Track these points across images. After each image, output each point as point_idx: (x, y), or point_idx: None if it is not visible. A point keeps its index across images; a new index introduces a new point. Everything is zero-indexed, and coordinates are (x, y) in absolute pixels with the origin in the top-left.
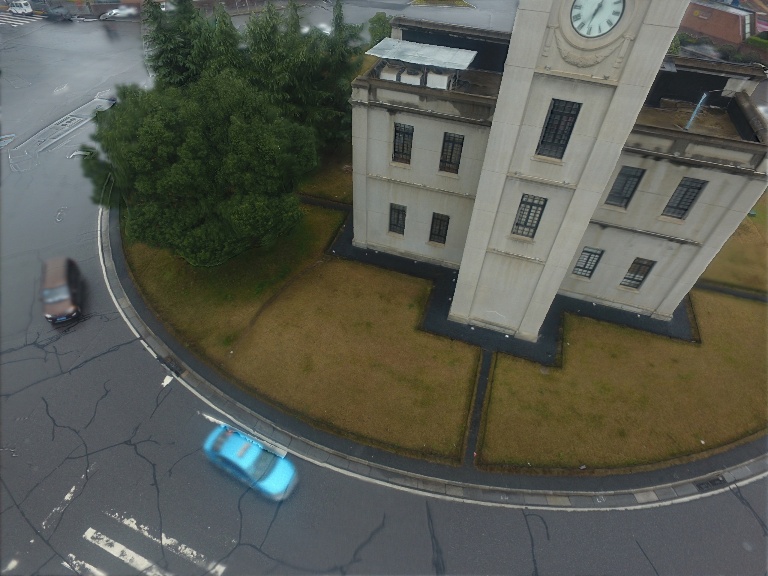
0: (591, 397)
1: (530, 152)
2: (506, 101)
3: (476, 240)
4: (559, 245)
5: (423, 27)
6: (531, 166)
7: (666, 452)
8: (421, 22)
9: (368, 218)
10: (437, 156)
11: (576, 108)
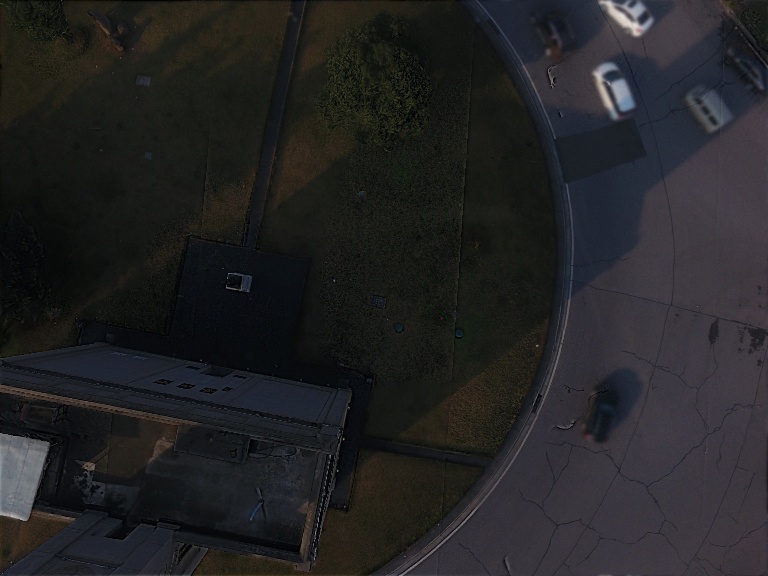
0: (256, 569)
1: None
2: None
3: None
4: None
5: None
6: None
7: None
8: None
9: None
10: None
11: None
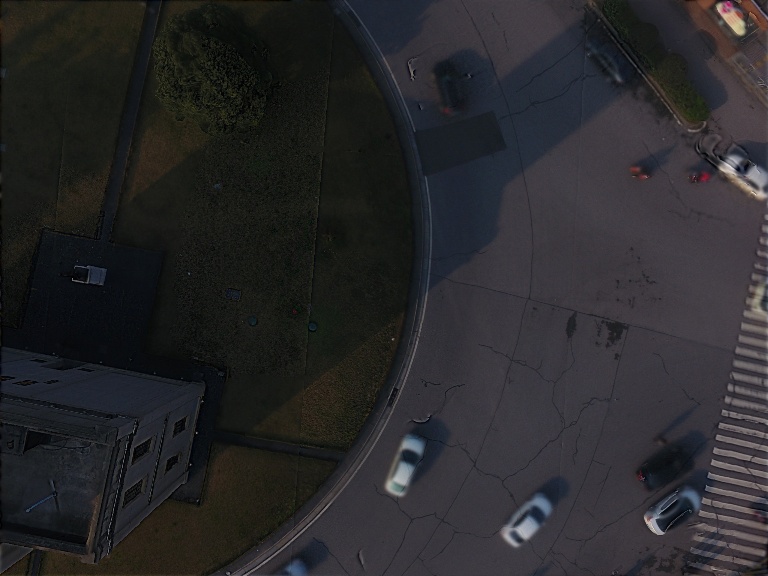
0: (107, 564)
1: None
2: None
3: None
4: None
5: None
6: None
7: None
8: None
9: None
10: None
11: None
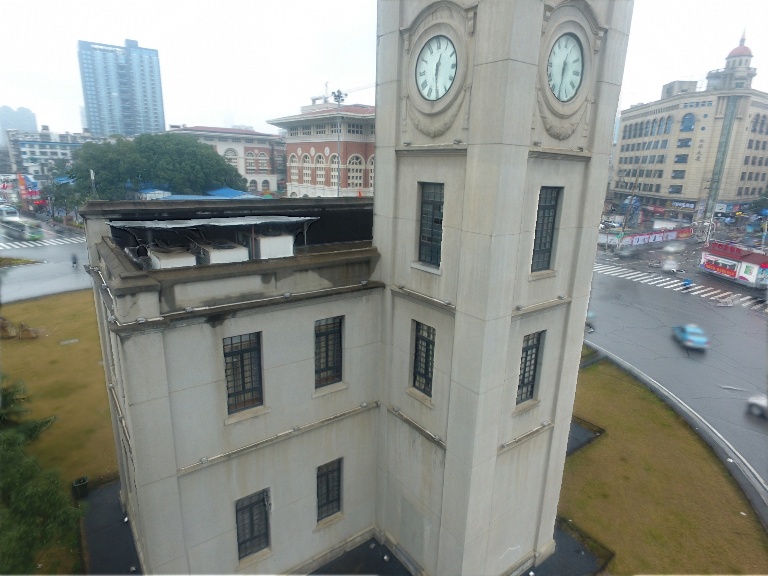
0: (671, 560)
1: (527, 271)
2: (505, 200)
3: (484, 447)
4: (564, 387)
5: (150, 208)
6: (529, 291)
7: (762, 552)
8: (143, 203)
9: (190, 567)
10: (309, 366)
11: (555, 196)
